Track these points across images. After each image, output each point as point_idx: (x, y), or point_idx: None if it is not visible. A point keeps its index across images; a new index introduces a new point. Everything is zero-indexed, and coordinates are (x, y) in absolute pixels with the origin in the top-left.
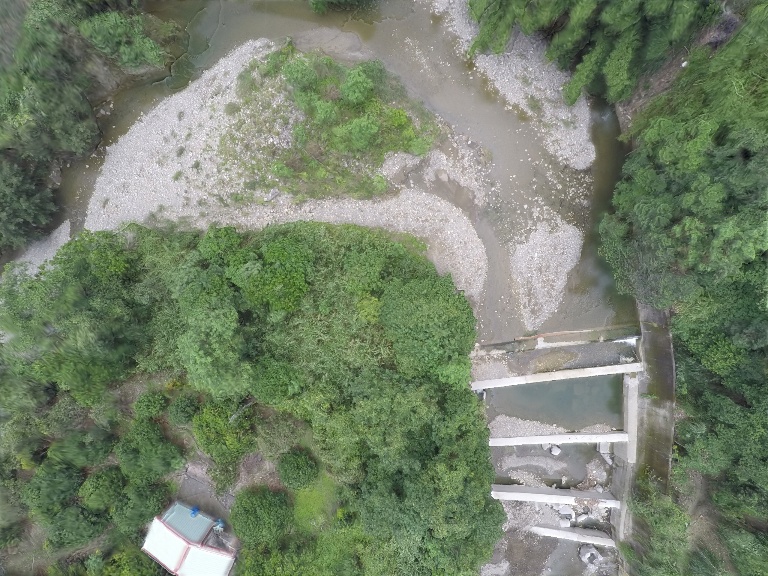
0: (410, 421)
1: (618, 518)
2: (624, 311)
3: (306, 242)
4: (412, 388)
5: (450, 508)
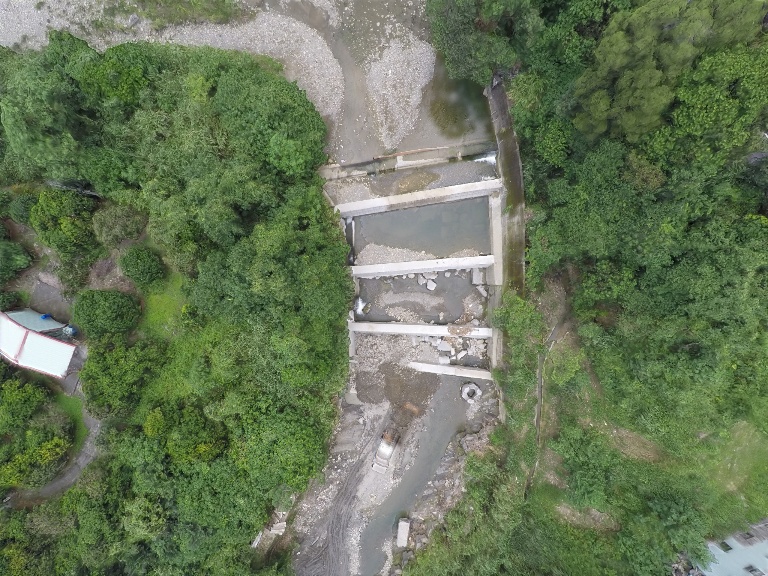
0: (234, 192)
1: (491, 346)
2: (481, 127)
3: (156, 54)
4: (236, 162)
5: (266, 266)
